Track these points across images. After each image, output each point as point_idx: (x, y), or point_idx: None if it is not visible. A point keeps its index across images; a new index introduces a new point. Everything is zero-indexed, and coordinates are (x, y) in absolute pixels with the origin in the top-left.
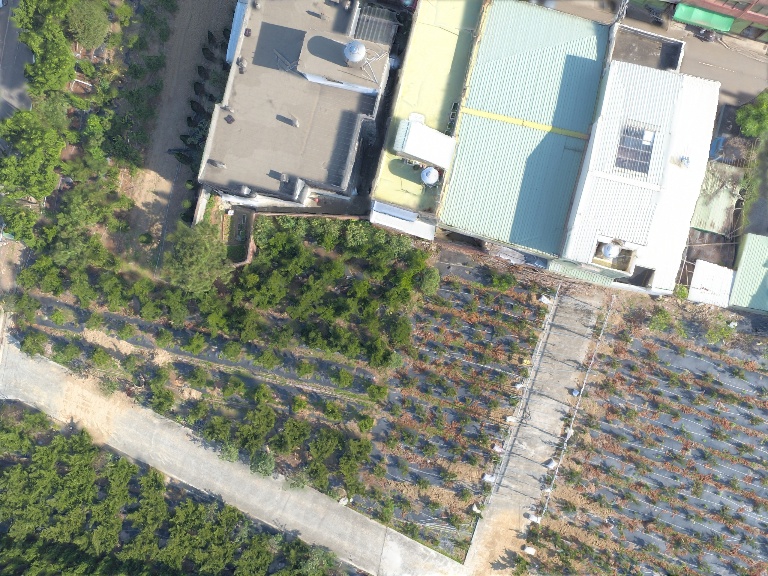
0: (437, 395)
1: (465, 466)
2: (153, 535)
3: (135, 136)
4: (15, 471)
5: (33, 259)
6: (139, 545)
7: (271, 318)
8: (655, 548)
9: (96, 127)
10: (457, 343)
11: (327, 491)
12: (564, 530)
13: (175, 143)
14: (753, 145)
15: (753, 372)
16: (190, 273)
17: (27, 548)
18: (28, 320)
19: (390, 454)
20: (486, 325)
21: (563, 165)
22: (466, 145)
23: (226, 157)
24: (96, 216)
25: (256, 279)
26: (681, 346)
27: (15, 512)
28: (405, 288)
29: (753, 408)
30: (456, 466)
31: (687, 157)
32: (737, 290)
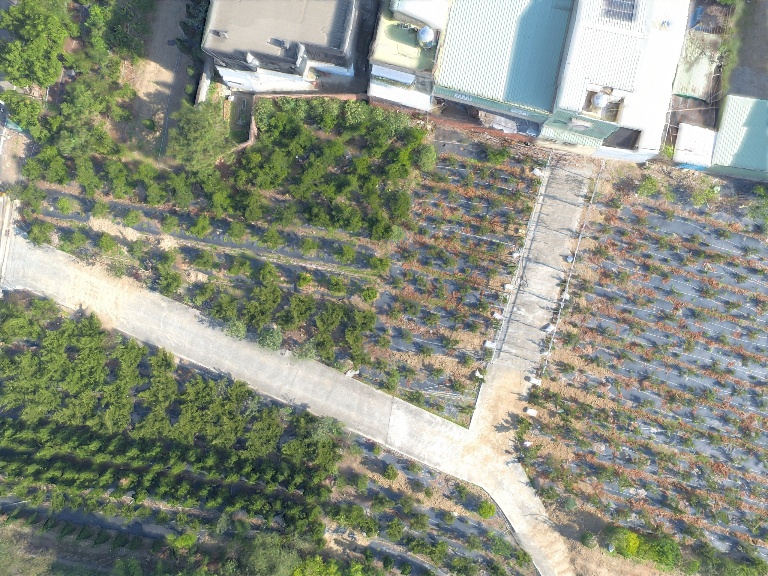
0: (437, 267)
1: (467, 334)
2: (165, 413)
3: (135, 26)
4: (26, 357)
5: (37, 152)
6: (152, 422)
7: (273, 200)
8: (651, 403)
9: (96, 17)
10: (454, 217)
11: (334, 364)
12: (564, 391)
13: (174, 34)
14: (728, 13)
15: (737, 234)
16: (194, 149)
17: (41, 429)
18: (34, 210)
19: (394, 326)
20: (482, 198)
21: (551, 24)
22: (458, 8)
23: (227, 27)
24: (99, 104)
25: (258, 158)
26: (668, 211)
27: (27, 396)
28: (403, 164)
29: (738, 267)
30: (458, 334)
31: (667, 22)
32: (719, 150)
